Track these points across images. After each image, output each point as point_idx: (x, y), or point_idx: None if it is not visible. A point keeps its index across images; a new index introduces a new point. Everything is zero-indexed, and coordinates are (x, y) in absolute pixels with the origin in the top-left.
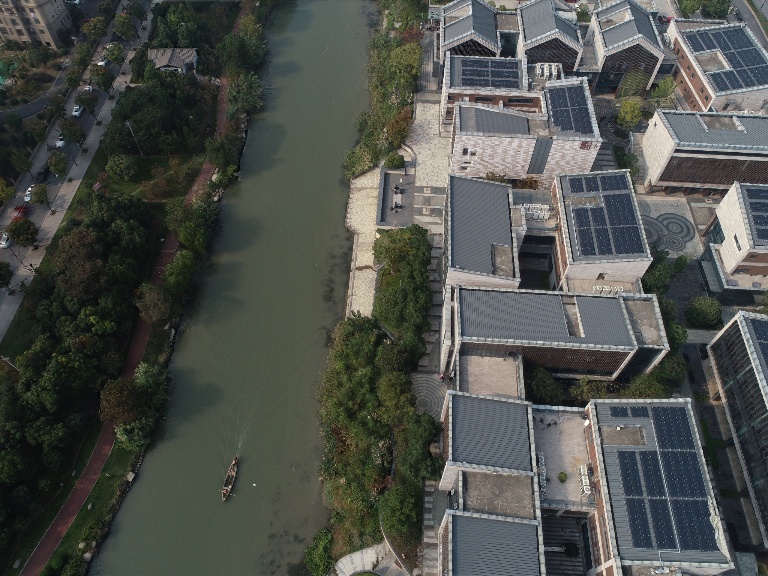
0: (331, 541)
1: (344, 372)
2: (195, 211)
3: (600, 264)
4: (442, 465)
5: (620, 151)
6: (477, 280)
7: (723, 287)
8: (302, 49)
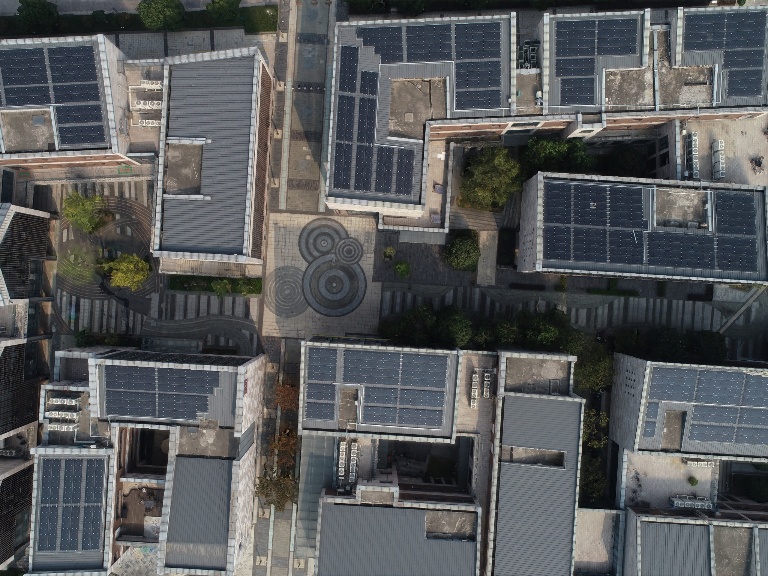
0: None
1: None
2: None
3: None
4: None
5: (180, 282)
6: None
7: None
8: None
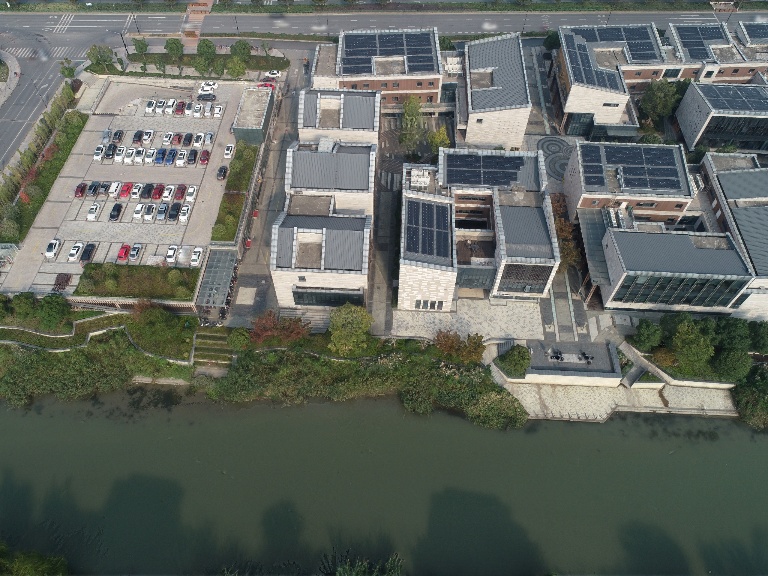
0: None
1: None
2: None
3: None
4: None
5: None
6: None
7: None
8: (222, 512)
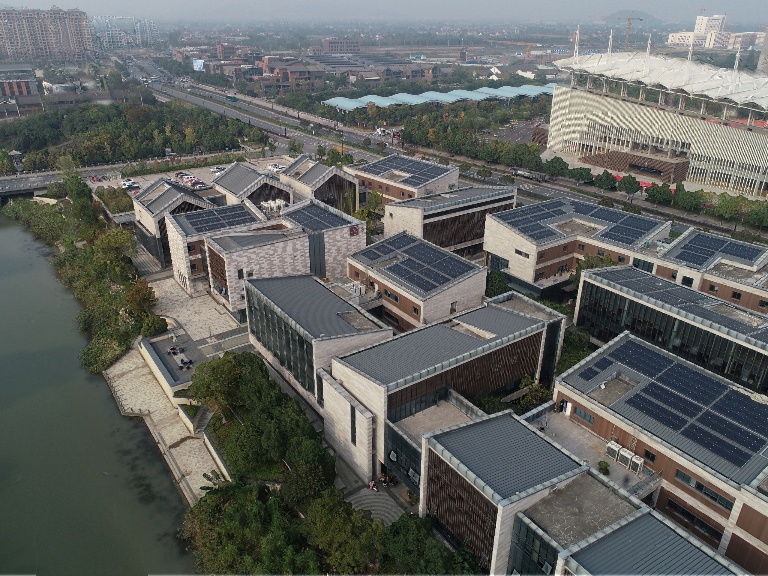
0: None
1: (240, 557)
2: None
3: (448, 290)
4: (473, 555)
5: None
6: (349, 347)
7: (539, 289)
8: None
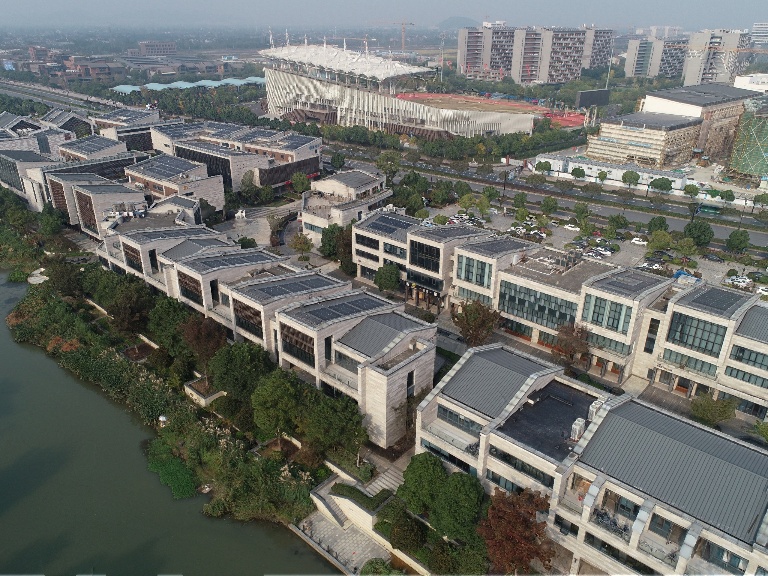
0: (21, 271)
1: None
2: None
3: (102, 151)
4: (66, 212)
5: None
6: None
7: None
8: None
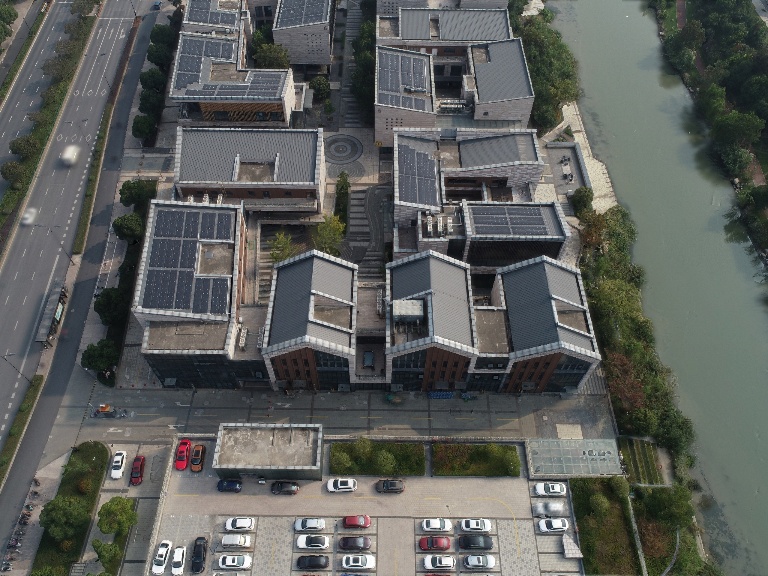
0: None
1: None
2: (737, 123)
3: None
4: None
5: None
6: None
7: None
8: None
